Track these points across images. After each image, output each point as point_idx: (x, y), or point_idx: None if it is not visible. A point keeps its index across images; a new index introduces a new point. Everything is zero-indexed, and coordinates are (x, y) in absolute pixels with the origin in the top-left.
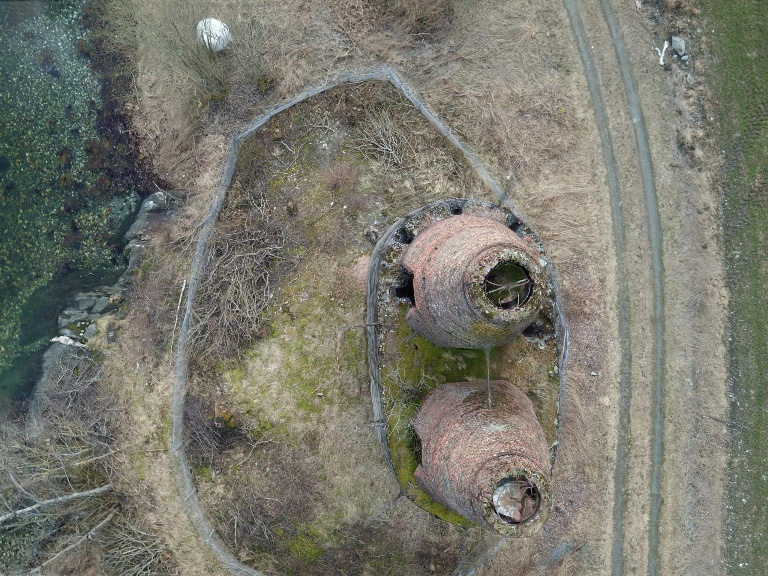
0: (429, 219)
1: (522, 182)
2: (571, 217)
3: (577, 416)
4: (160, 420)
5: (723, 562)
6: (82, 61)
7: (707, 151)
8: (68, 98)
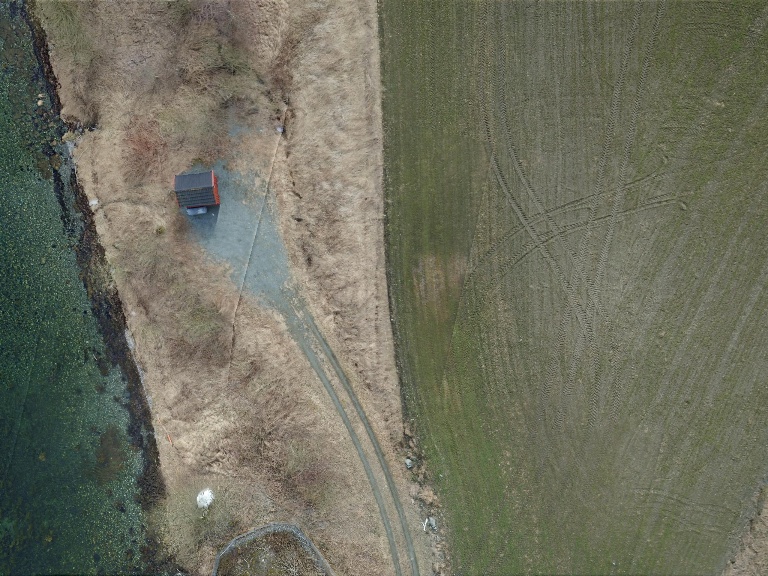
0: None
1: None
2: None
3: None
4: None
5: None
6: (137, 504)
7: (447, 573)
8: (130, 523)
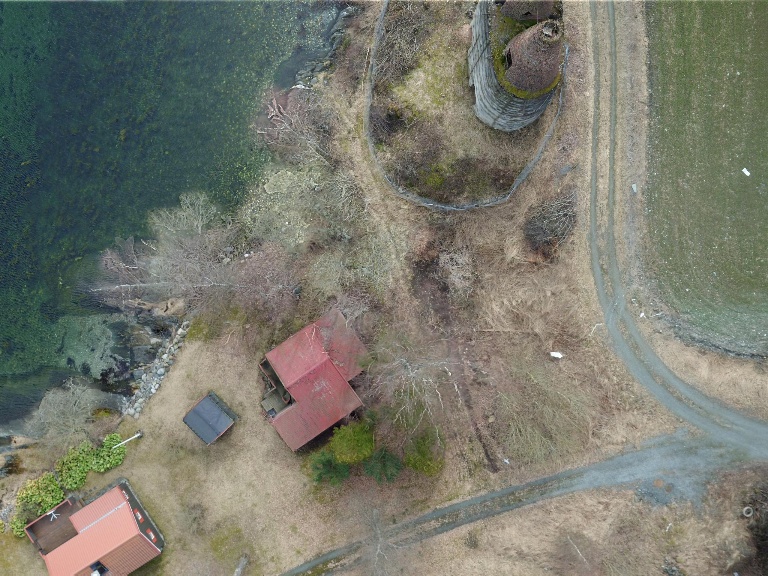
0: None
1: None
2: (569, 2)
3: (573, 99)
4: (356, 121)
5: (647, 173)
6: None
7: None
8: None
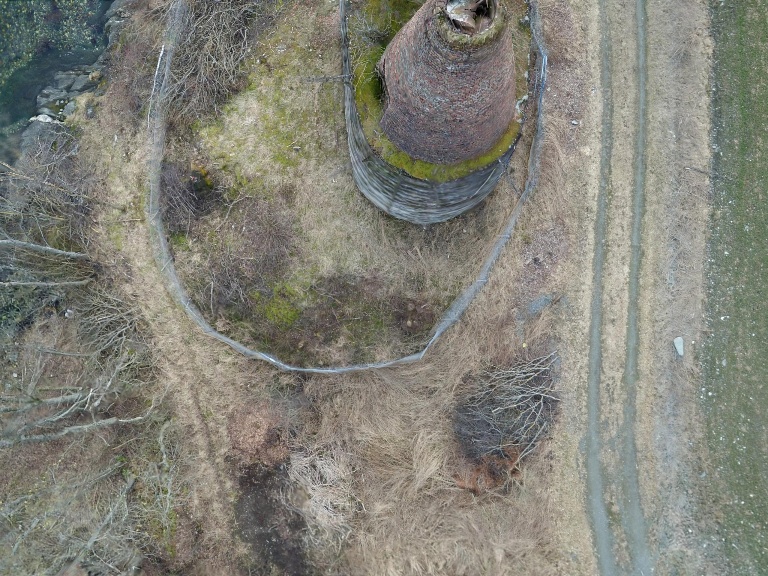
0: None
1: None
2: None
3: (557, 162)
4: (137, 189)
5: (704, 316)
6: None
7: None
8: None
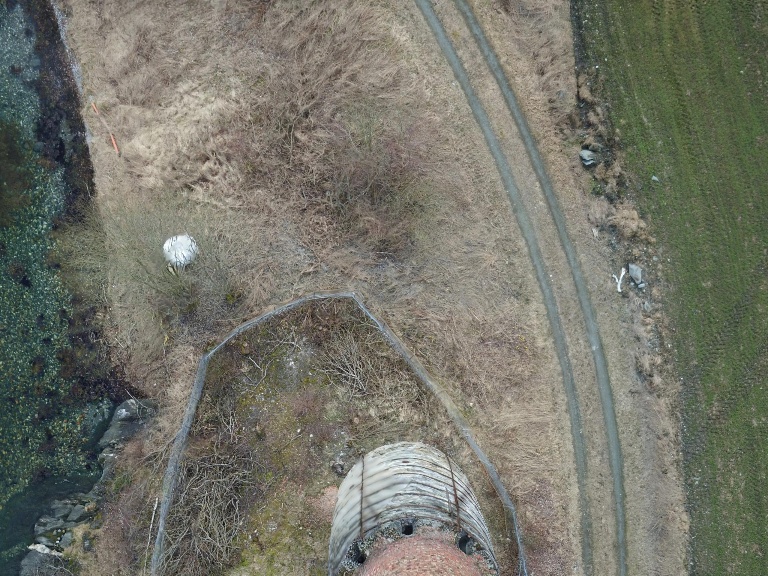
0: (380, 539)
1: (485, 409)
2: (533, 447)
3: None
4: None
5: None
6: (53, 271)
7: (665, 377)
8: (40, 307)
